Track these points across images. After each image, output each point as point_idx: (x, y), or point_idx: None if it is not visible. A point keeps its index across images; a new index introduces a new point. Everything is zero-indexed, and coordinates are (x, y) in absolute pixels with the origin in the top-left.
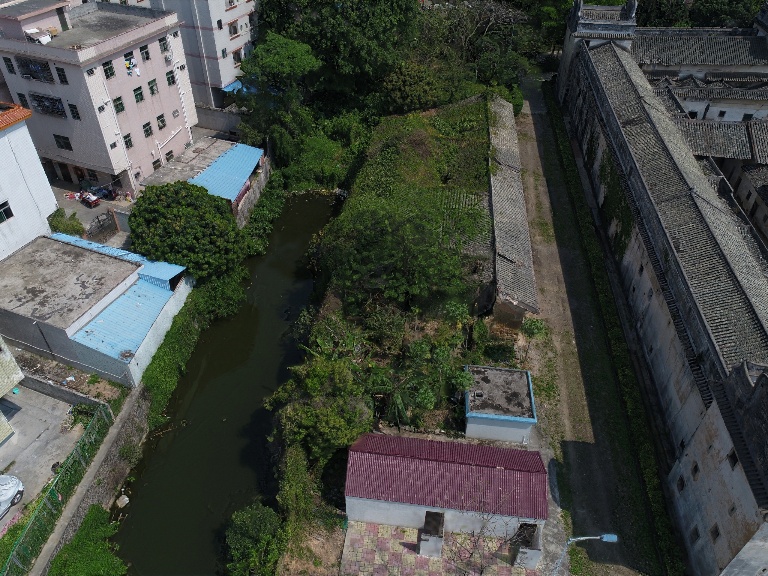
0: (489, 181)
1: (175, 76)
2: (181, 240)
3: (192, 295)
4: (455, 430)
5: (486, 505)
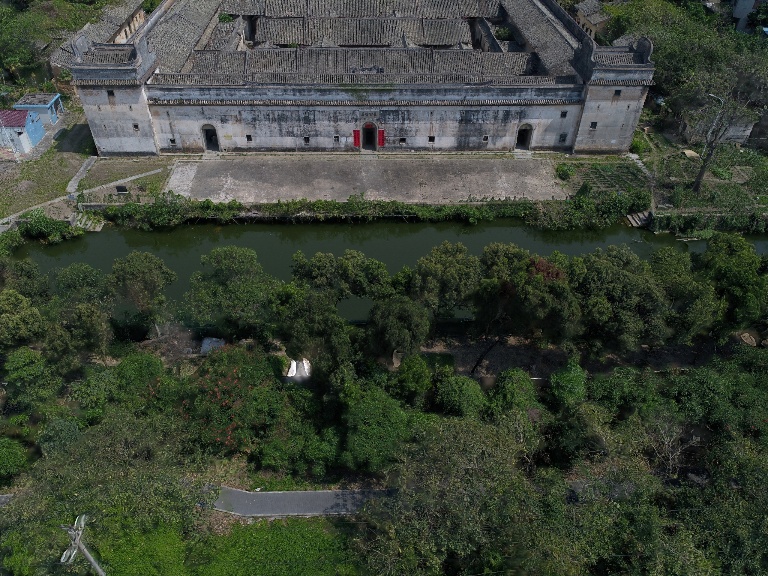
0: None
1: None
2: None
3: None
4: None
5: None
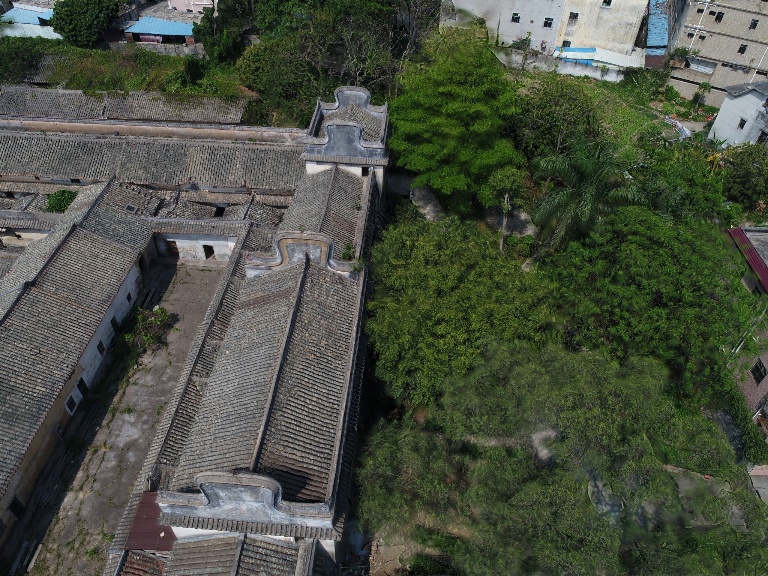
0: None
1: None
2: (55, 8)
3: (57, 39)
4: None
5: None
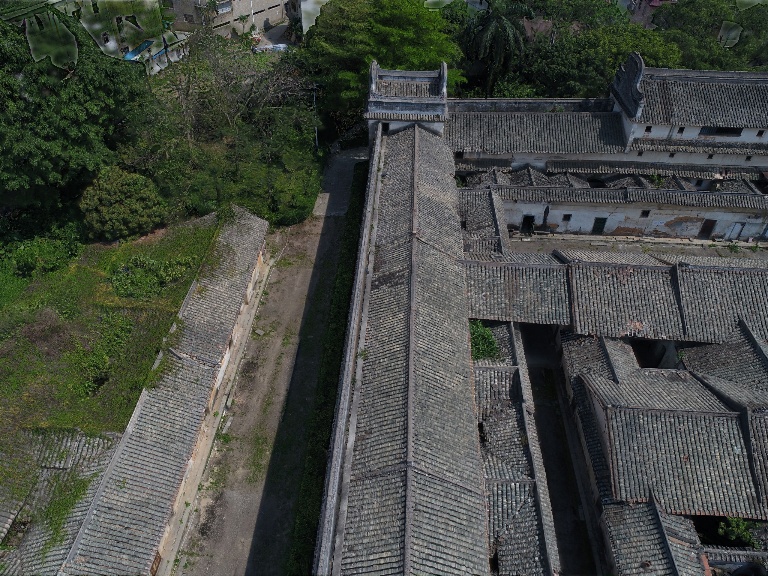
0: (136, 404)
1: None
2: None
3: None
4: None
5: None
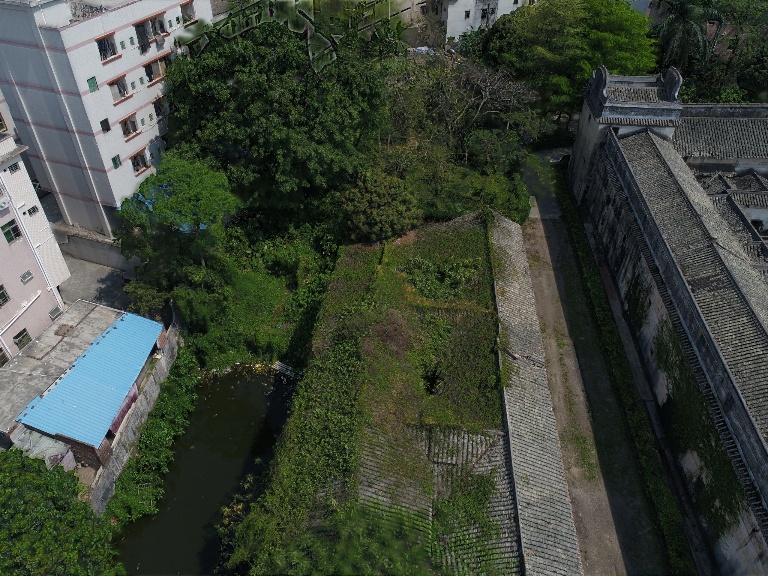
0: (502, 403)
1: (20, 226)
2: None
3: None
4: None
5: None
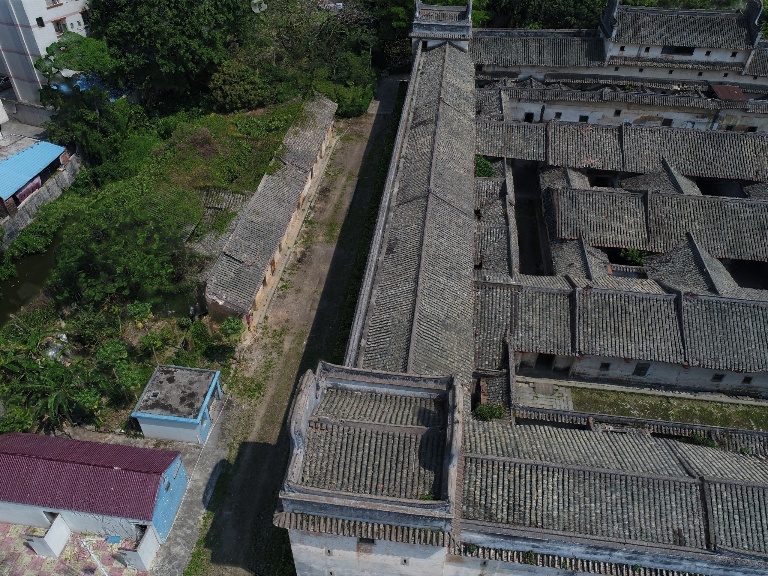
0: None
1: None
2: None
3: None
4: (135, 430)
5: (94, 505)
